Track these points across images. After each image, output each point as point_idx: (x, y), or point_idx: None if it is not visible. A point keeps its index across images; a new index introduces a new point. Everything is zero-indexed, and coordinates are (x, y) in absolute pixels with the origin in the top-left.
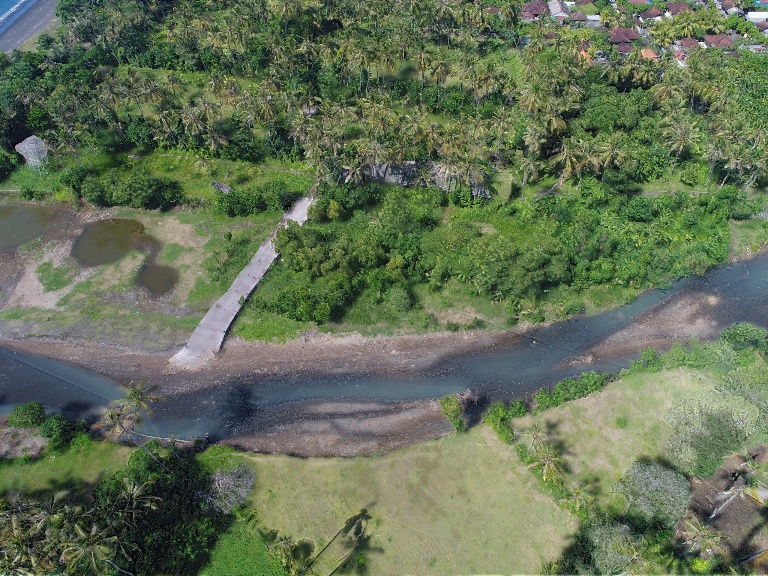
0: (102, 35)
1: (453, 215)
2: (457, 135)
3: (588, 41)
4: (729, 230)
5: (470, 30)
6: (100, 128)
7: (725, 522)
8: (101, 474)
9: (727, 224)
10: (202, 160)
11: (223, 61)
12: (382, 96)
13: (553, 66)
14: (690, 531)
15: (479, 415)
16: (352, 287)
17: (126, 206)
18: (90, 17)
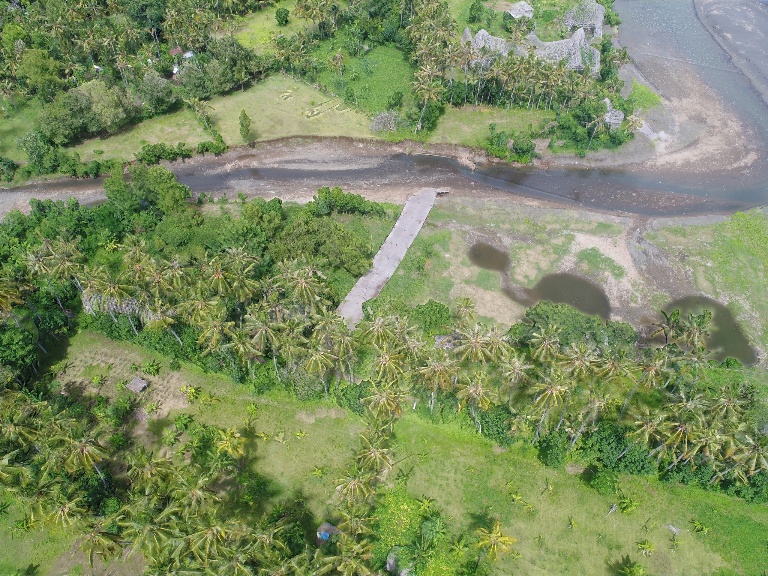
0: None
1: None
2: None
3: None
4: None
5: None
6: None
7: None
8: (463, 133)
9: None
10: None
11: None
12: None
13: None
14: None
15: (228, 159)
16: None
17: None
18: None
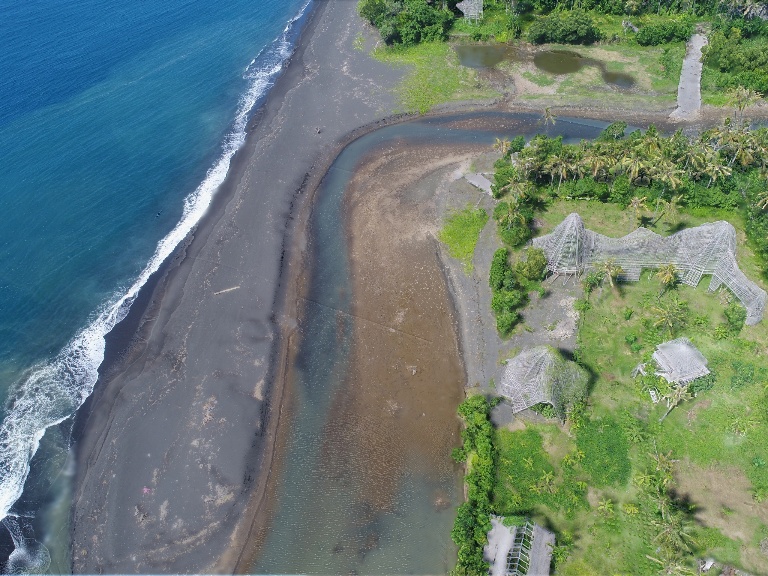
0: None
1: None
2: None
3: None
4: None
5: None
6: None
7: None
8: None
9: None
10: (634, 0)
11: None
12: None
13: None
14: None
15: None
16: None
17: (555, 43)
18: None
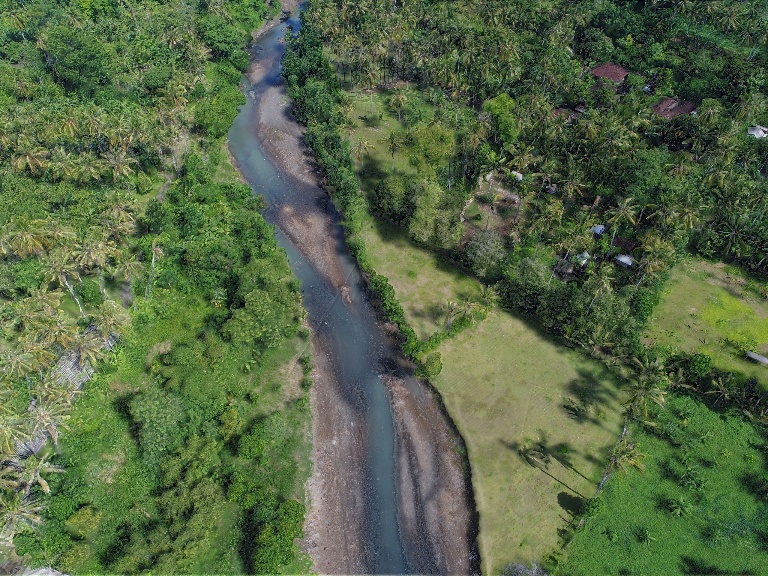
0: None
1: None
2: None
3: None
4: None
5: None
6: None
7: None
8: None
9: None
10: None
11: None
12: None
13: None
14: (514, 237)
15: (406, 369)
16: None
17: None
18: None
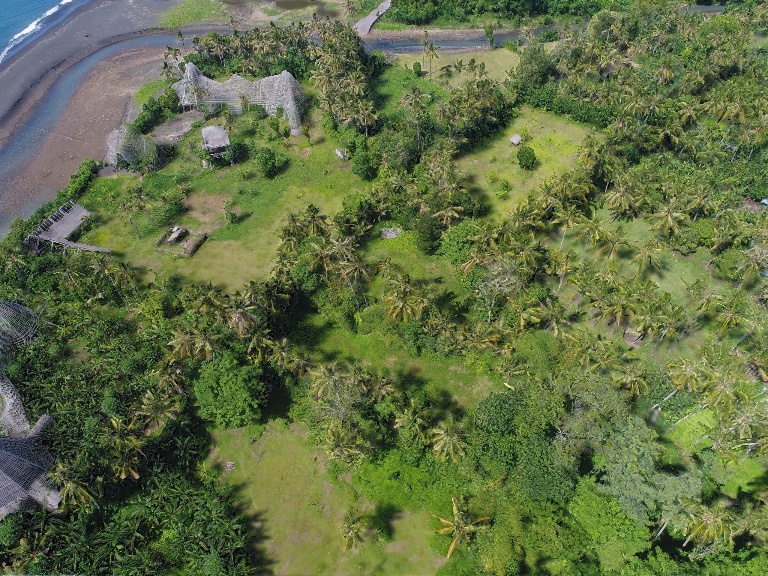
0: None
1: None
2: None
3: None
4: None
5: None
6: None
7: None
8: None
9: None
10: None
11: None
12: None
13: None
14: None
15: None
16: (434, 11)
17: None
18: None
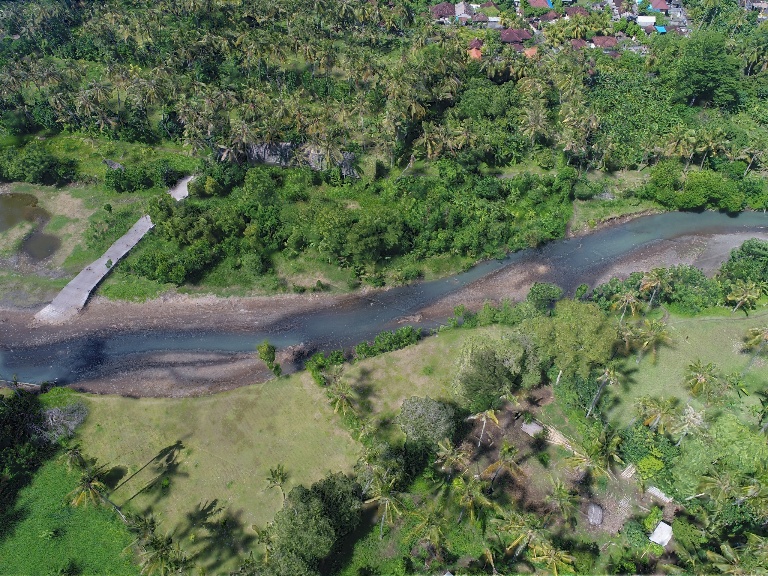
0: (26, 27)
1: (323, 193)
2: (320, 117)
3: (484, 40)
4: (572, 209)
5: (371, 28)
6: (7, 110)
7: (498, 453)
8: None
9: (571, 203)
10: (90, 138)
11: (138, 53)
12: (280, 86)
13: (430, 59)
14: (442, 451)
15: None
16: (213, 253)
17: (25, 182)
18: (12, 9)
